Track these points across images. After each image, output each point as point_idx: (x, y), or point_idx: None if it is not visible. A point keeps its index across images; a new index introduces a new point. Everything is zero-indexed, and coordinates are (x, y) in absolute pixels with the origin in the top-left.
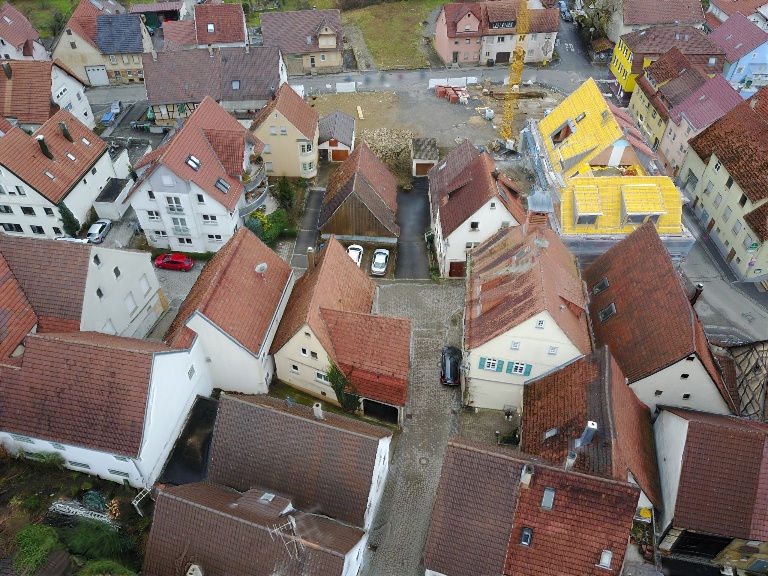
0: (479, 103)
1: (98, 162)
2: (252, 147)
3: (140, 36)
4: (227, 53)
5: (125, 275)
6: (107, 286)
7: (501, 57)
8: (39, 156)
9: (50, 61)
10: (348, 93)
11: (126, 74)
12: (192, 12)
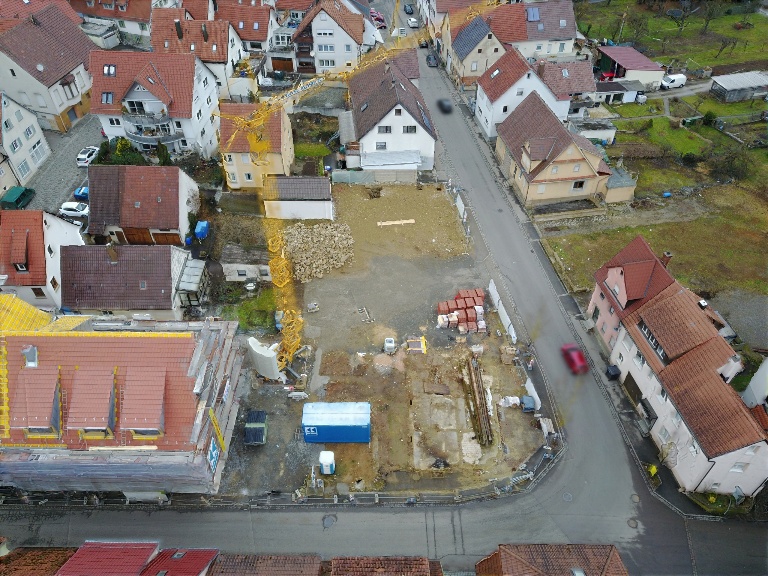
0: (439, 342)
1: (209, 65)
2: (163, 104)
3: (473, 47)
4: (388, 79)
5: (20, 80)
6: (3, 73)
7: (632, 385)
8: (175, 32)
9: (321, 6)
10: (457, 213)
11: (456, 73)
12: (682, 90)
